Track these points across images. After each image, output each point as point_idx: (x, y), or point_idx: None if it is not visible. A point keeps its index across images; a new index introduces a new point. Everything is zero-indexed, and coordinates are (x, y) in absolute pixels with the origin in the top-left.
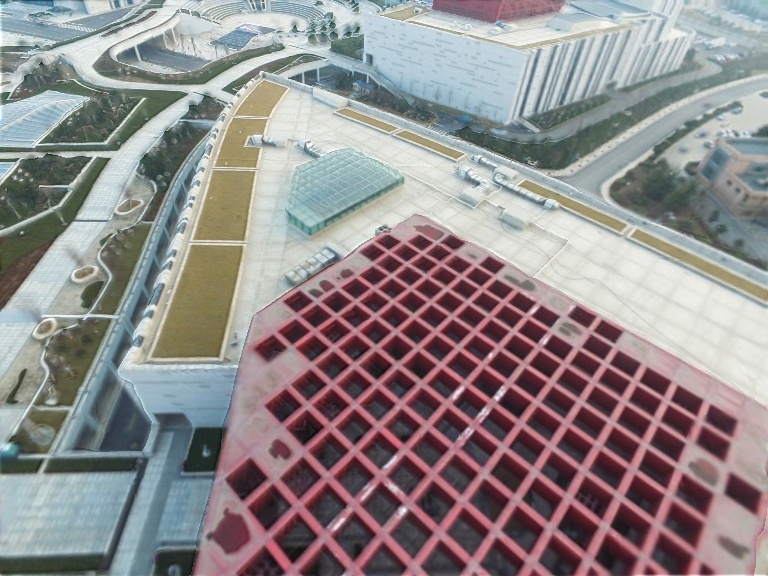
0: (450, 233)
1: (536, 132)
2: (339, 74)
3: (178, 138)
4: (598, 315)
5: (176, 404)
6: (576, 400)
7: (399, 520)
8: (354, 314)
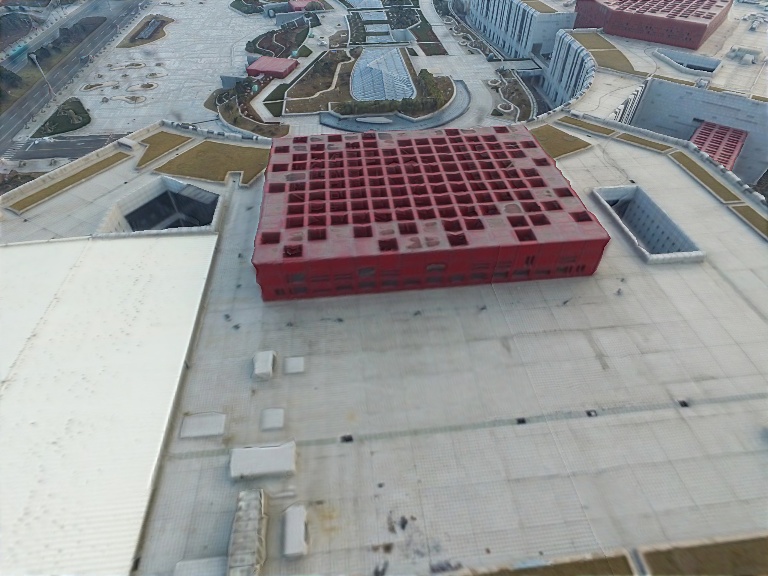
0: None
1: None
2: None
3: None
4: None
5: (543, 37)
6: None
7: (647, 4)
8: None
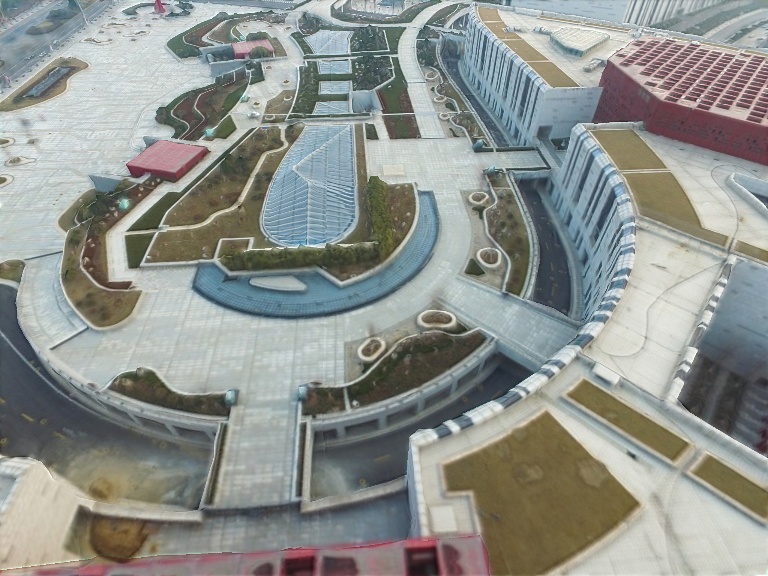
0: (667, 39)
1: None
2: None
3: None
4: (752, 55)
5: (554, 118)
6: None
7: (711, 88)
8: None
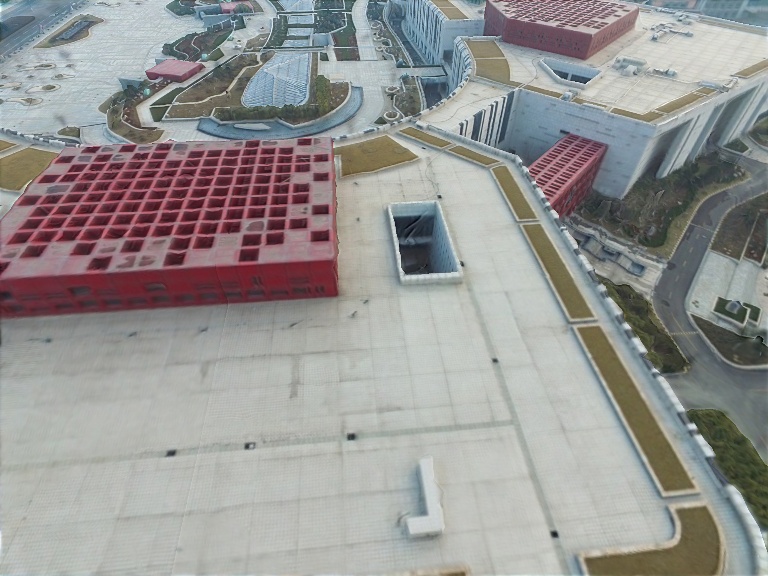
0: None
1: None
2: None
3: None
4: None
5: None
6: (584, 4)
7: None
8: None
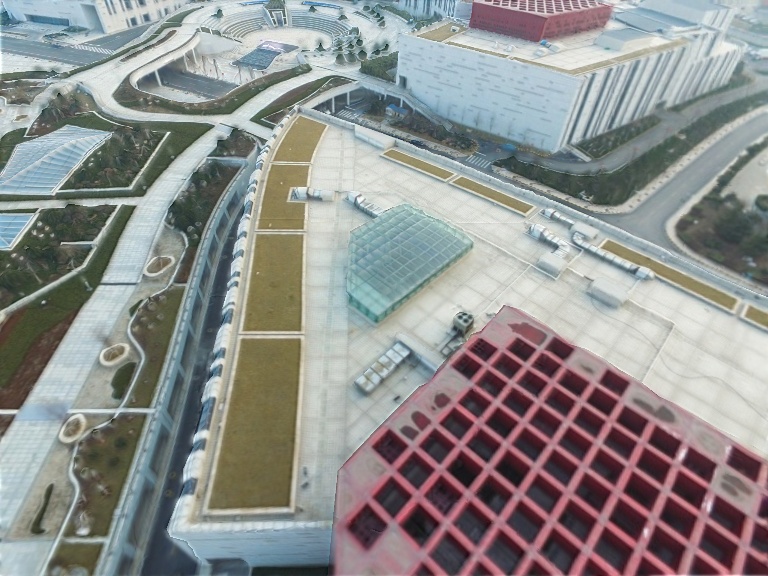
0: (554, 334)
1: (587, 161)
2: (370, 97)
3: (207, 179)
4: (763, 461)
5: (234, 552)
6: None
7: None
8: (461, 464)
